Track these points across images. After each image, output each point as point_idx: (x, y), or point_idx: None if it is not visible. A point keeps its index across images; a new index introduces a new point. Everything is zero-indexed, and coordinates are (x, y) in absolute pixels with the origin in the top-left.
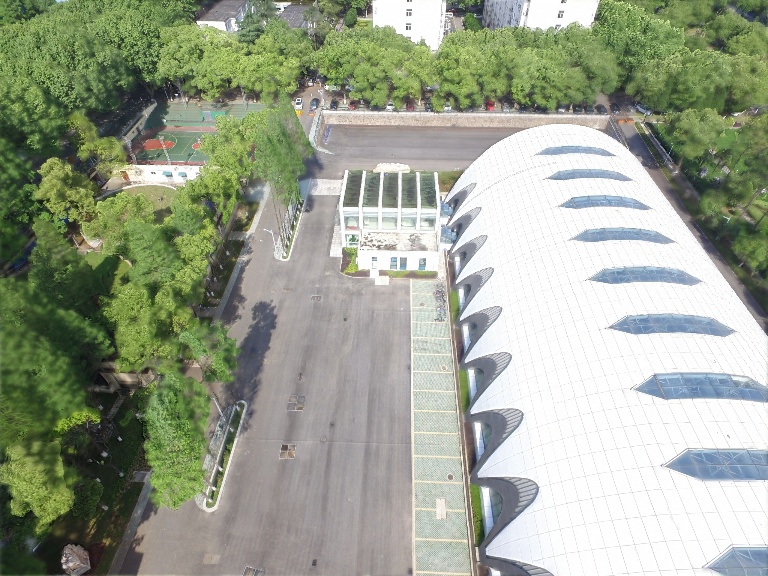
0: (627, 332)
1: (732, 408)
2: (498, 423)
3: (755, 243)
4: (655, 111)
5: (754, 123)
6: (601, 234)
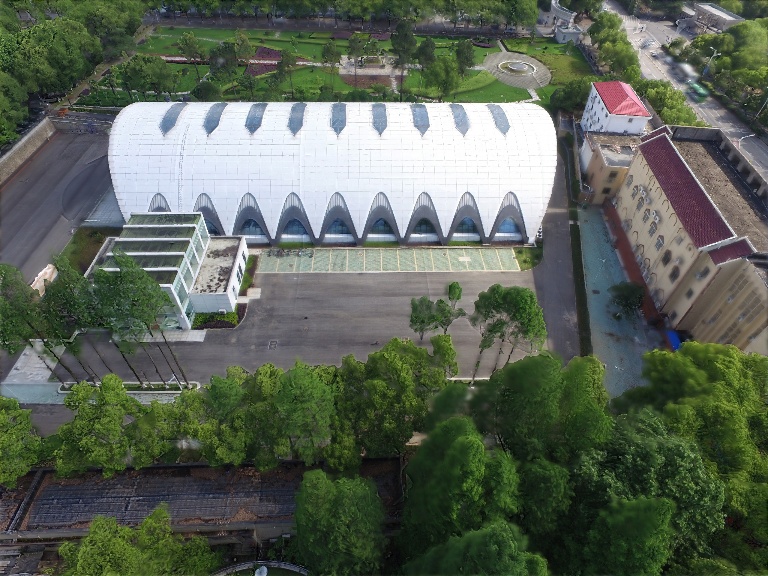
0: (385, 129)
1: (432, 111)
2: (423, 211)
3: (273, 98)
4: (60, 94)
5: (189, 40)
6: (295, 121)
